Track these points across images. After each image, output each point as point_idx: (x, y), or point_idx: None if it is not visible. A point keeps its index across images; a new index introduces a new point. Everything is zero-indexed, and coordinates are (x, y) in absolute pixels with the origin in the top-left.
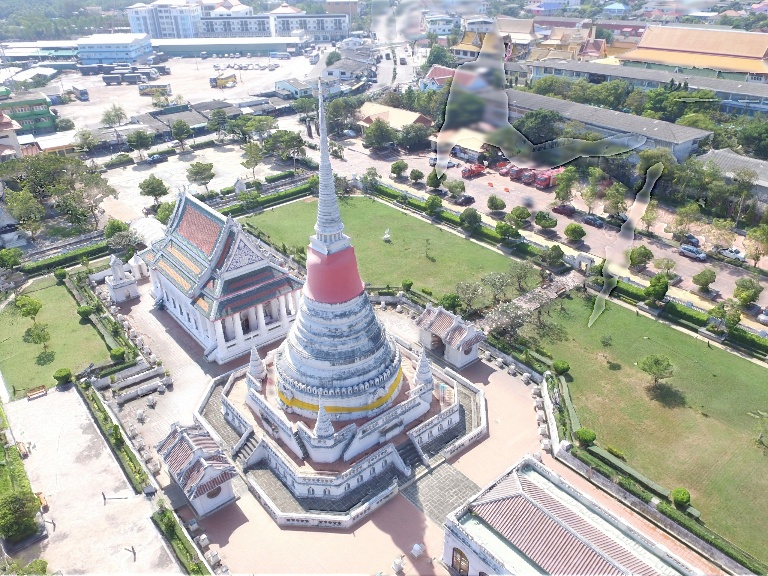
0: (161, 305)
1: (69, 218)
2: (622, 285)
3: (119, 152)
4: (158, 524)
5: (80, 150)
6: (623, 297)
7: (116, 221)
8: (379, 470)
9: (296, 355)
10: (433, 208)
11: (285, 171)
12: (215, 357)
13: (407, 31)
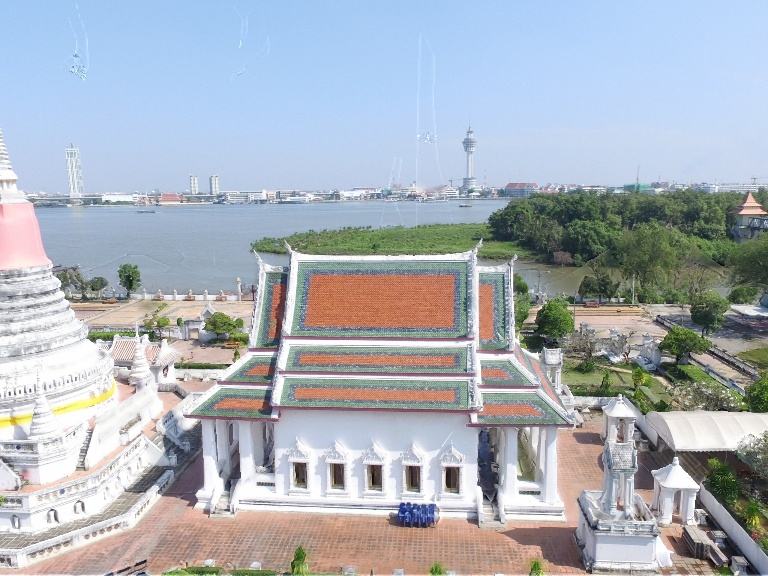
0: None
1: None
2: None
3: None
4: None
5: None
6: None
7: None
8: None
9: None
10: None
11: None
12: None
13: None
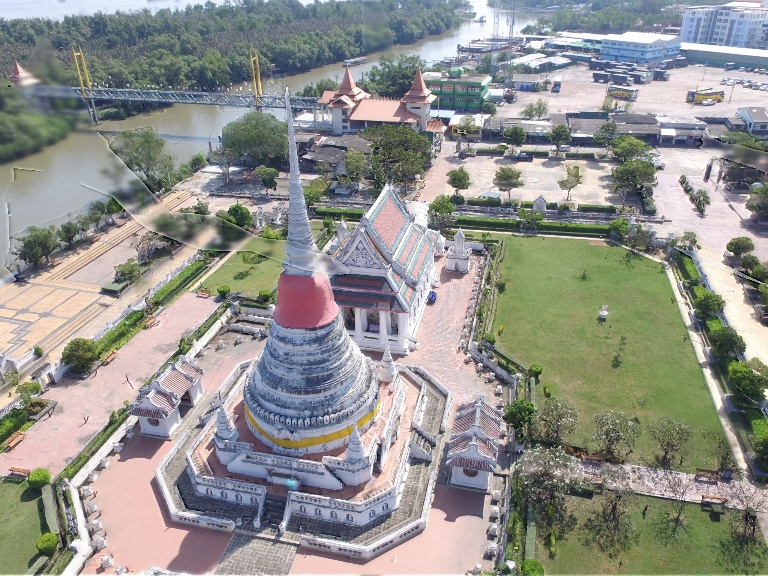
0: None
1: (375, 183)
2: None
3: (503, 143)
4: None
5: (461, 132)
6: None
7: None
8: (247, 502)
9: None
10: (700, 308)
11: (613, 205)
12: None
13: None
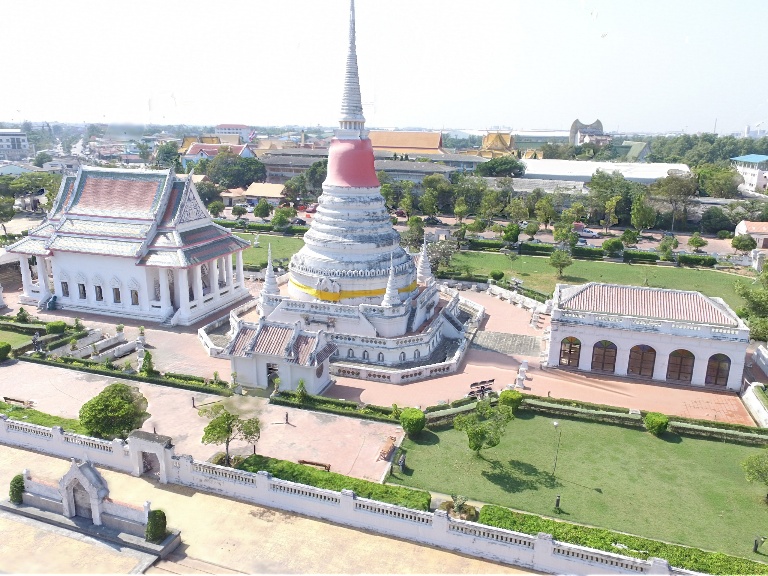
0: (53, 303)
1: None
2: (482, 241)
3: None
4: (286, 402)
5: None
6: (487, 248)
7: None
8: (439, 339)
9: (337, 246)
10: (283, 223)
11: None
12: (177, 321)
13: (132, 130)
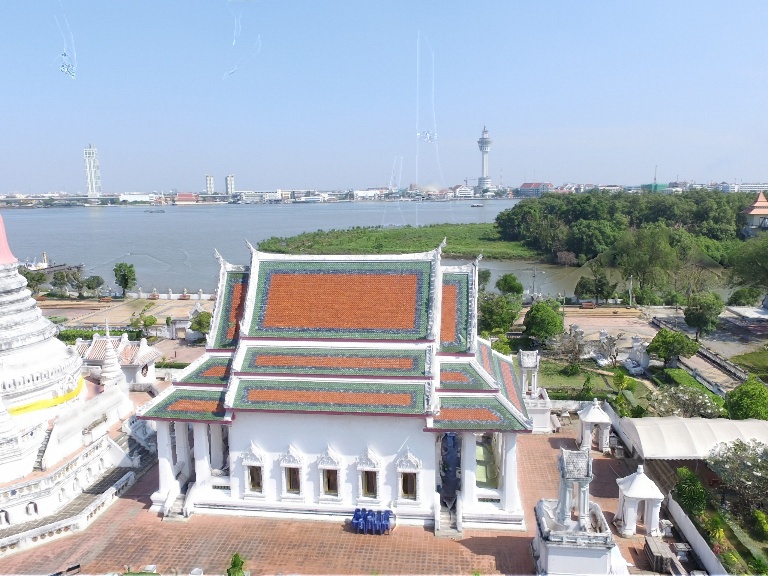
0: None
1: None
2: None
3: None
4: None
5: None
6: None
7: (752, 385)
8: None
9: None
10: None
11: None
12: None
13: None
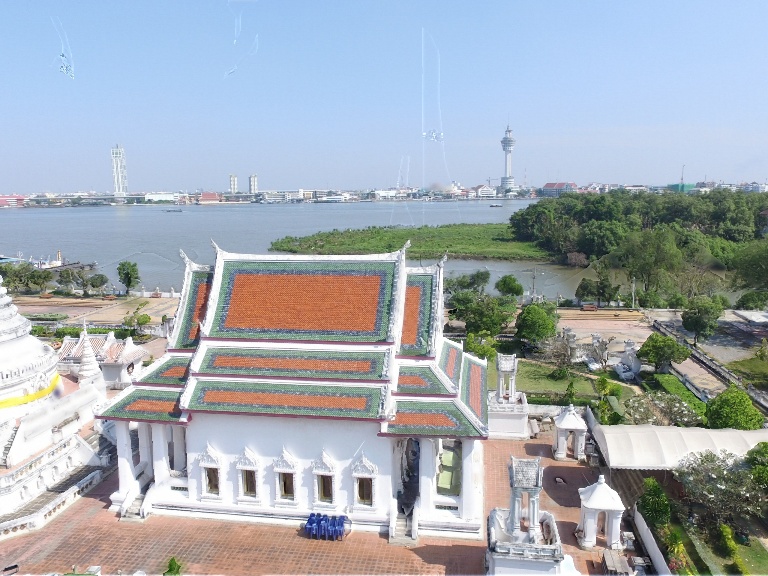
0: None
1: None
2: None
3: None
4: None
5: None
6: None
7: None
8: None
9: None
10: None
11: None
12: None
13: None
